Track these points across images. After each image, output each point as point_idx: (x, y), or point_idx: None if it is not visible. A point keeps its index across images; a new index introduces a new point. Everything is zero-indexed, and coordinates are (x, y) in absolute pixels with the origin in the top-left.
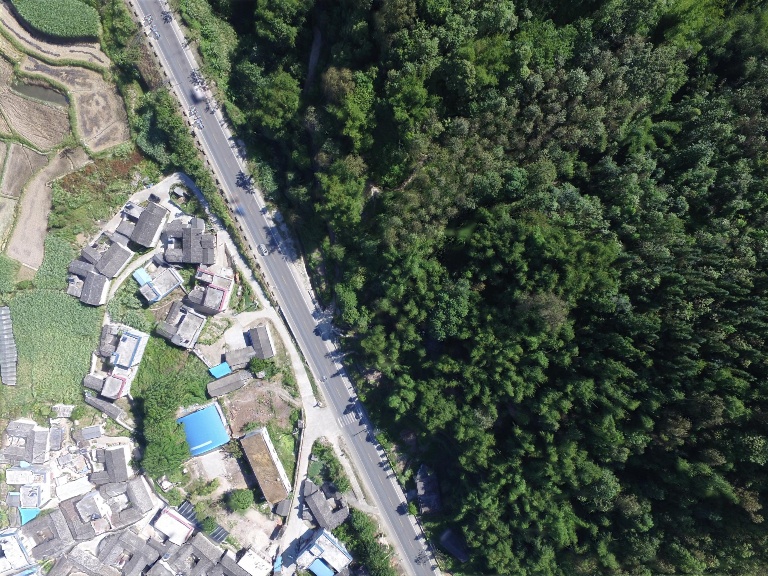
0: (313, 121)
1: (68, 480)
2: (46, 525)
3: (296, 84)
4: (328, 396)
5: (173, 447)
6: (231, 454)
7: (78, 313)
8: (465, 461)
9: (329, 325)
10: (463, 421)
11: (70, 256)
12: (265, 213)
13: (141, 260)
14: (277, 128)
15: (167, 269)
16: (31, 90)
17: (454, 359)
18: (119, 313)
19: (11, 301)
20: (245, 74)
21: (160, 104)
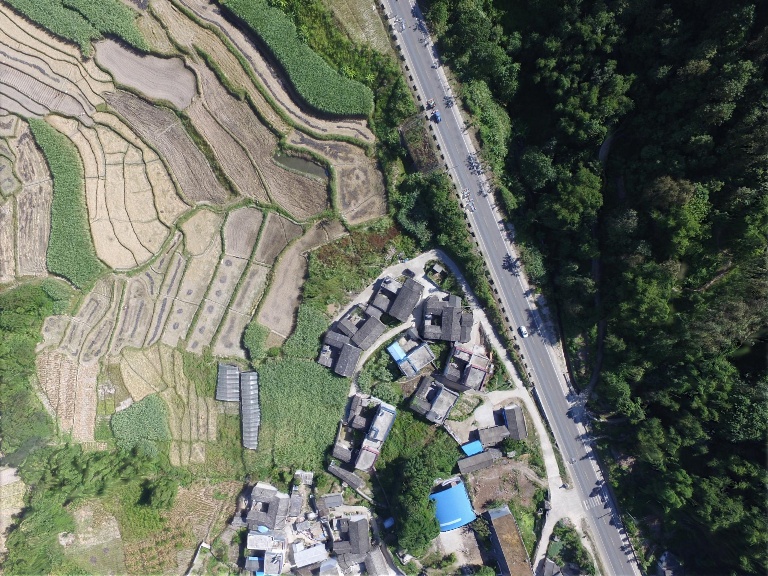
0: (632, 224)
1: (304, 547)
2: None
3: (598, 181)
4: (576, 478)
5: (429, 525)
6: (470, 529)
7: (328, 383)
8: (746, 561)
9: (583, 408)
10: (758, 525)
11: (324, 326)
12: (528, 296)
13: (391, 333)
14: (575, 223)
15: (424, 345)
16: (292, 162)
17: (749, 462)
18: (369, 385)
19: (261, 368)
20: (537, 165)
21: (439, 187)
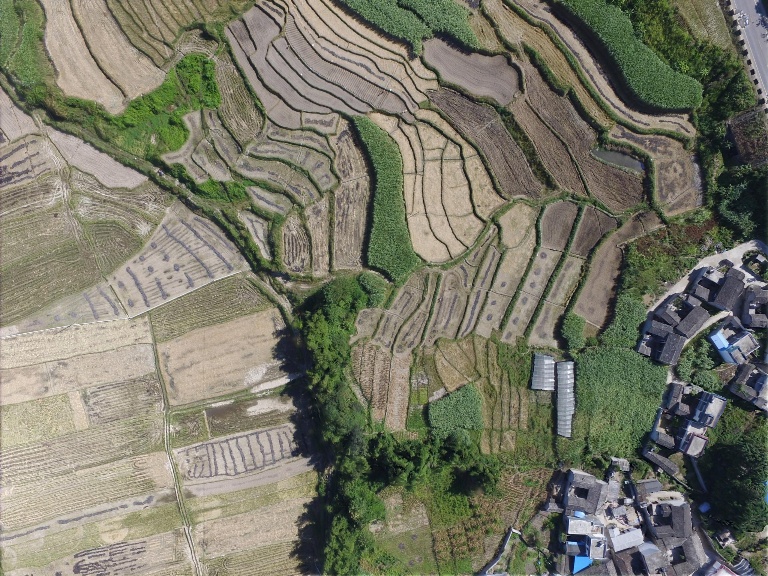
0: None
1: (619, 531)
2: (598, 574)
3: None
4: None
5: None
6: None
7: (648, 371)
8: None
9: None
10: None
11: (644, 316)
12: None
13: (708, 322)
14: None
15: (749, 333)
16: (610, 156)
17: None
18: (690, 373)
19: (580, 357)
20: None
21: None
